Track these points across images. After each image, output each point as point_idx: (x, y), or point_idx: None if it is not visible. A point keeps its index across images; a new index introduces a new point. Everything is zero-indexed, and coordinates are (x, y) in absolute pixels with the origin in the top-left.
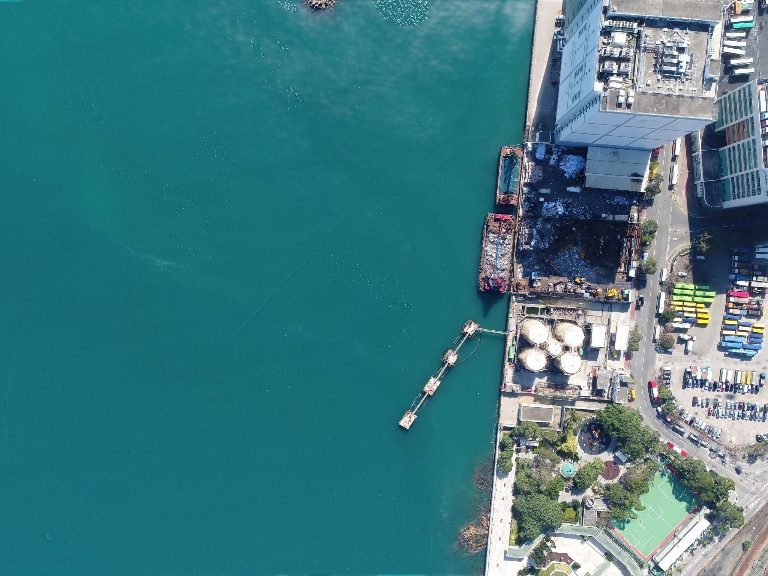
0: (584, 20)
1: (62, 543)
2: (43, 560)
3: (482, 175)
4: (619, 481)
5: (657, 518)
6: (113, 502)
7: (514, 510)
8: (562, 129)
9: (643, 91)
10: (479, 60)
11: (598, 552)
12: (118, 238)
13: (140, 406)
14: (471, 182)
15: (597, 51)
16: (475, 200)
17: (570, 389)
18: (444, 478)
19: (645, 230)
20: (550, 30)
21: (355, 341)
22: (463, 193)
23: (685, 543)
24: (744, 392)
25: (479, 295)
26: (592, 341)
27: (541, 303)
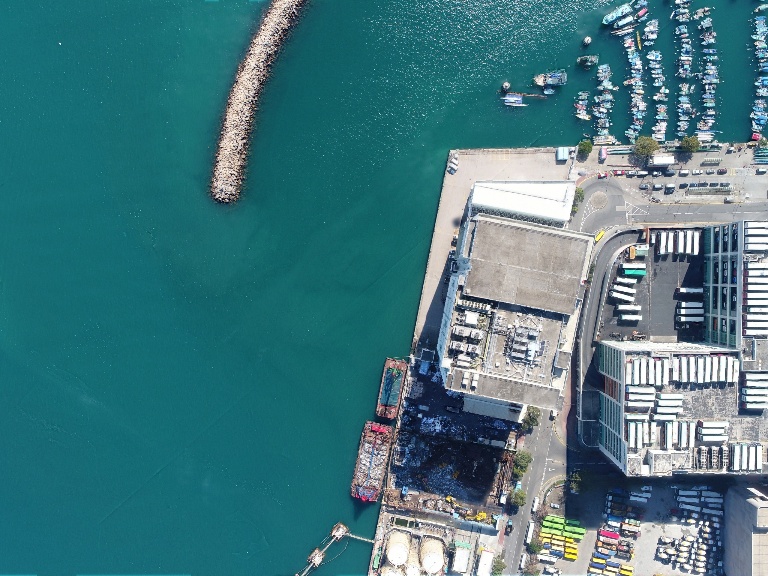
0: (455, 275)
1: None
2: None
3: (366, 382)
4: None
5: None
6: None
7: None
8: None
9: (491, 372)
10: (374, 268)
11: None
12: (11, 399)
13: None
14: (353, 388)
15: (448, 328)
16: (356, 406)
17: None
18: None
19: (517, 463)
20: (446, 248)
21: (227, 527)
22: (344, 398)
23: None
24: None
25: (352, 499)
26: (454, 565)
27: (411, 516)
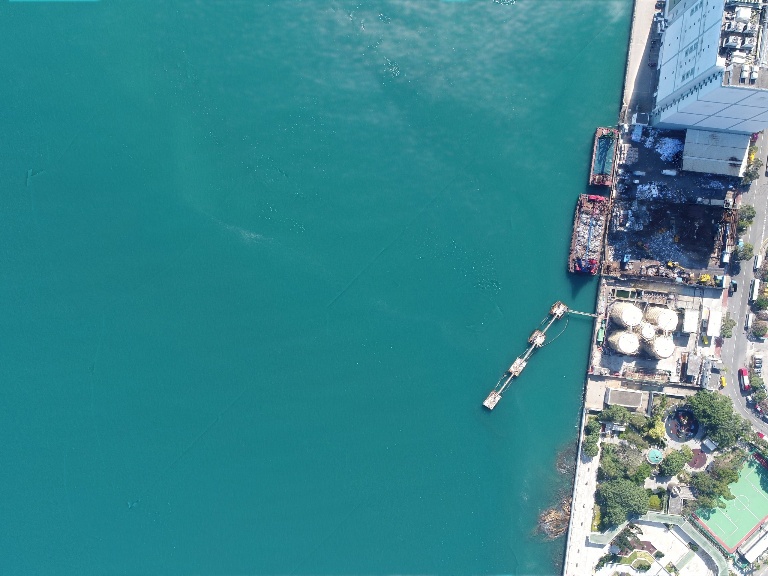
0: None
1: (145, 510)
2: (119, 529)
3: (576, 156)
4: (706, 470)
5: (743, 509)
6: (199, 470)
7: (597, 496)
8: (663, 110)
9: (766, 67)
10: (576, 40)
11: (682, 542)
12: (206, 208)
13: (229, 375)
14: (565, 162)
15: (721, 26)
16: (568, 180)
17: (659, 374)
18: (526, 461)
19: (743, 215)
20: (650, 12)
21: (440, 319)
22: (556, 173)
23: None
24: None
25: (568, 276)
26: (684, 326)
27: (632, 286)
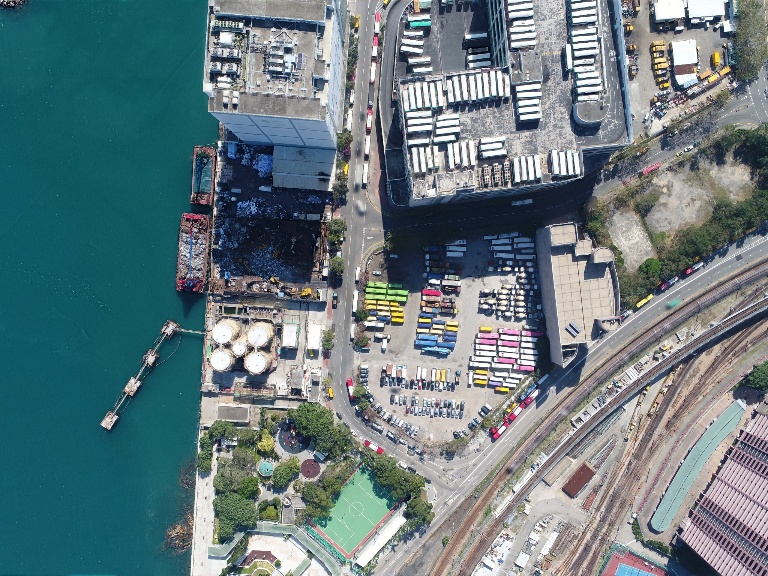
0: None
1: None
2: None
3: (178, 175)
4: (318, 479)
5: (358, 515)
6: None
7: None
8: None
9: (253, 91)
10: (172, 59)
11: (301, 550)
12: None
13: None
14: (166, 182)
15: None
16: (170, 200)
17: (267, 388)
18: (149, 478)
19: (330, 229)
20: None
21: (58, 342)
22: (157, 193)
23: (381, 540)
24: (440, 390)
25: (179, 295)
26: (283, 340)
27: (238, 303)
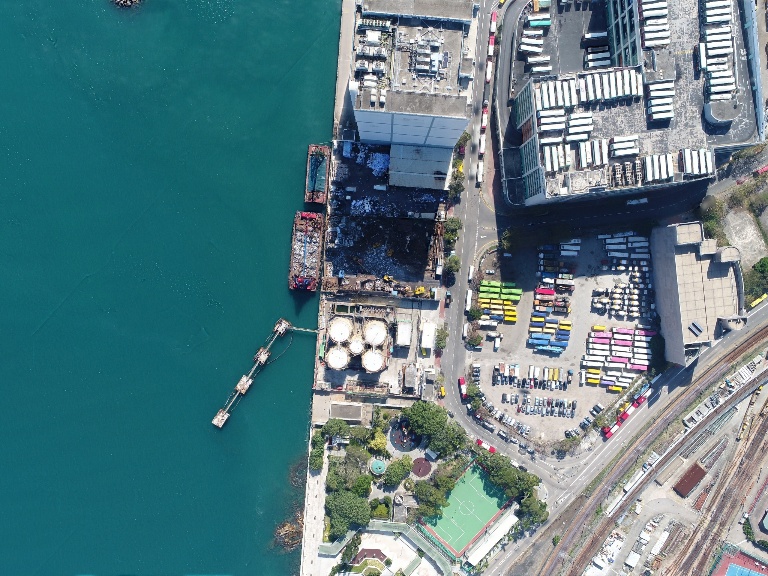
0: None
1: None
2: None
3: (291, 173)
4: (429, 478)
5: (469, 514)
6: None
7: None
8: None
9: (399, 90)
10: (287, 58)
11: (411, 548)
12: None
13: None
14: (280, 180)
15: None
16: (284, 198)
17: (379, 387)
18: (259, 476)
19: (447, 228)
20: None
21: (169, 340)
22: (271, 191)
23: (493, 538)
24: (552, 389)
25: (291, 293)
26: (398, 339)
27: (351, 301)
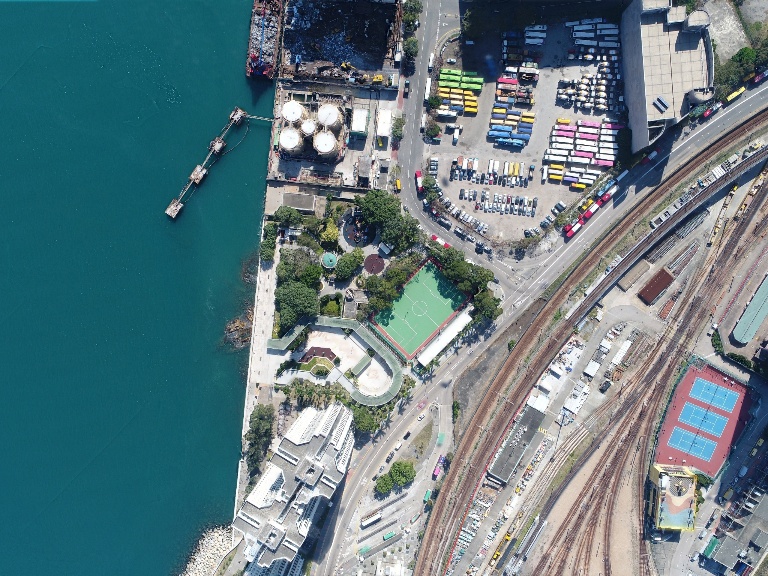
0: None
1: None
2: None
3: None
4: (382, 274)
5: (422, 315)
6: None
7: (277, 303)
8: None
9: None
10: None
11: (361, 348)
12: None
13: None
14: None
15: None
16: None
17: (334, 177)
18: (210, 270)
19: (406, 8)
20: None
21: (127, 130)
22: None
23: (445, 338)
24: (512, 185)
25: (248, 83)
26: (353, 125)
27: (308, 90)
